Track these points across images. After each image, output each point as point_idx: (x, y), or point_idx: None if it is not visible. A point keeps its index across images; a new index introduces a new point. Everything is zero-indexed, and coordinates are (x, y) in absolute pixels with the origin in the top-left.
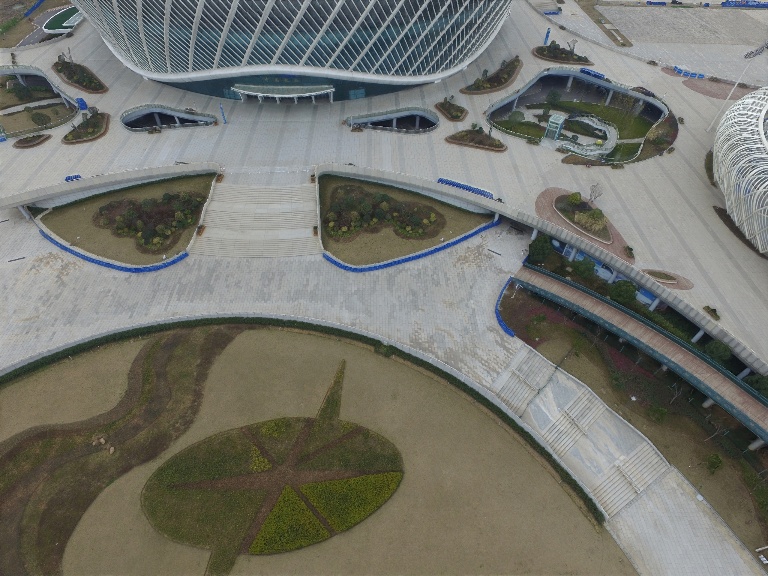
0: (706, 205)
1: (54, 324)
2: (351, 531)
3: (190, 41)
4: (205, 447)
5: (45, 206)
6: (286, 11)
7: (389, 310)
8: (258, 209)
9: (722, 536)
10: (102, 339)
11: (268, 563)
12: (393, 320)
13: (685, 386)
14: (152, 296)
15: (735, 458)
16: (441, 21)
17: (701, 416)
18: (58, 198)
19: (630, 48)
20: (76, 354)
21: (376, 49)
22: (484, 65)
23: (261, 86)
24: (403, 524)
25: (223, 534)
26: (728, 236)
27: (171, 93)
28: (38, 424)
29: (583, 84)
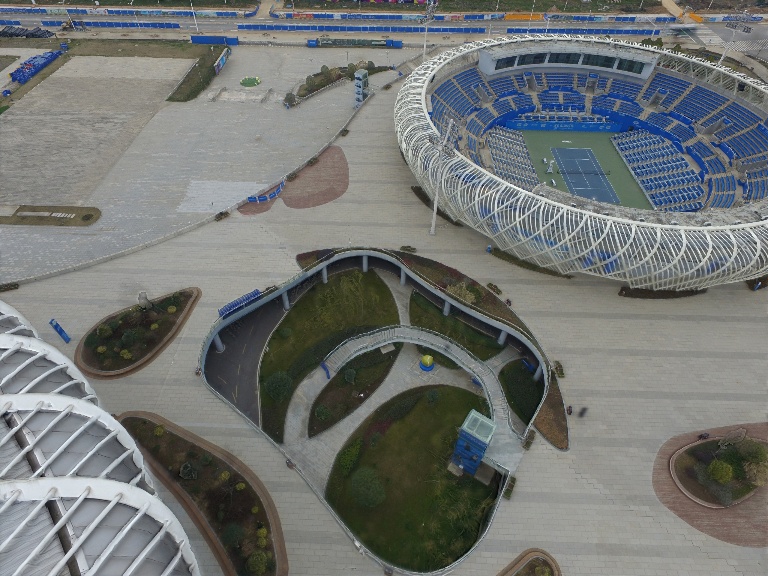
0: (620, 301)
1: None
2: None
3: None
4: None
5: None
6: None
7: None
8: None
9: None
10: None
11: None
12: None
13: None
14: None
15: None
16: None
17: None
18: None
19: (105, 215)
20: None
21: None
22: None
23: None
24: None
25: None
26: (679, 305)
27: None
28: None
29: None
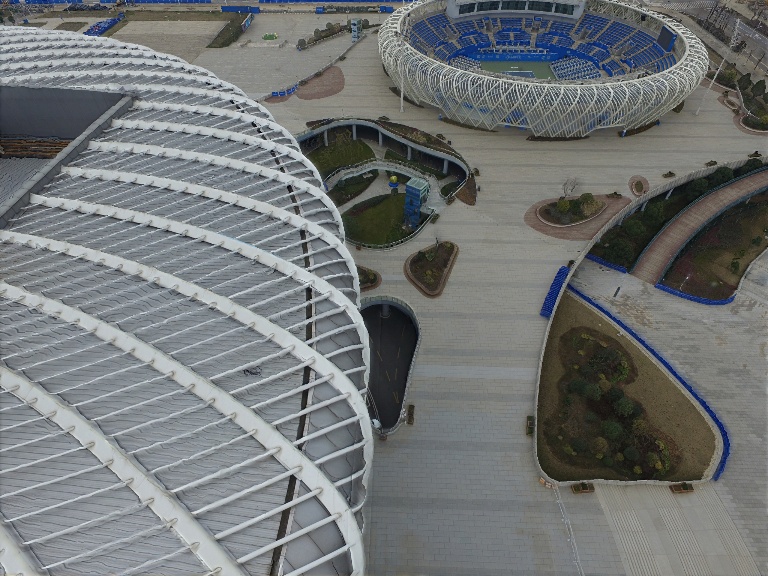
0: (526, 143)
1: None
2: None
3: None
4: None
5: None
6: None
7: (766, 399)
8: None
9: None
10: None
11: None
12: None
13: None
14: None
15: None
16: None
17: None
18: None
19: None
20: None
21: None
22: None
23: None
24: None
25: None
26: (567, 144)
27: None
28: None
29: None
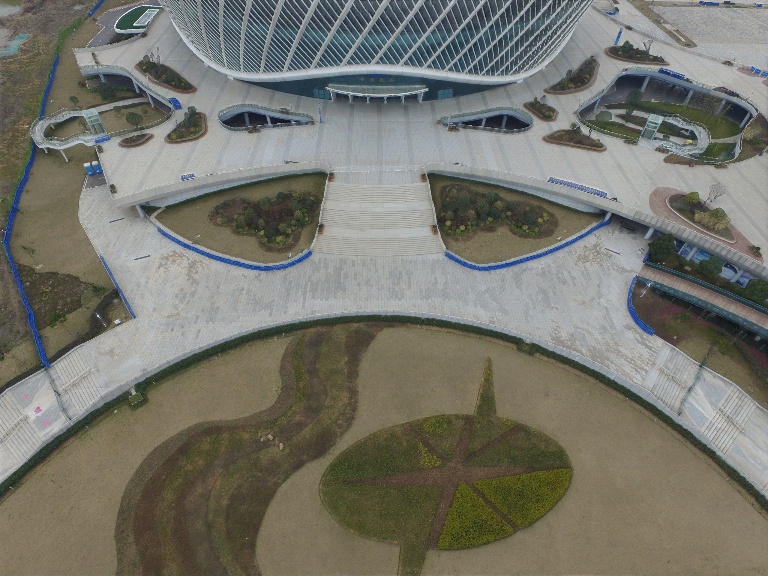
0: None
1: (197, 321)
2: (533, 527)
3: (294, 41)
4: (372, 443)
5: (158, 205)
6: (399, 11)
7: (524, 308)
8: (374, 208)
9: None
10: (248, 336)
11: (458, 558)
12: (530, 318)
13: None
14: (286, 294)
15: None
16: (538, 21)
17: None
18: (172, 197)
19: (695, 48)
20: (224, 351)
21: (475, 49)
22: (561, 65)
23: (355, 86)
24: (583, 520)
25: (408, 529)
26: None
27: (259, 93)
28: (202, 420)
29: (657, 84)
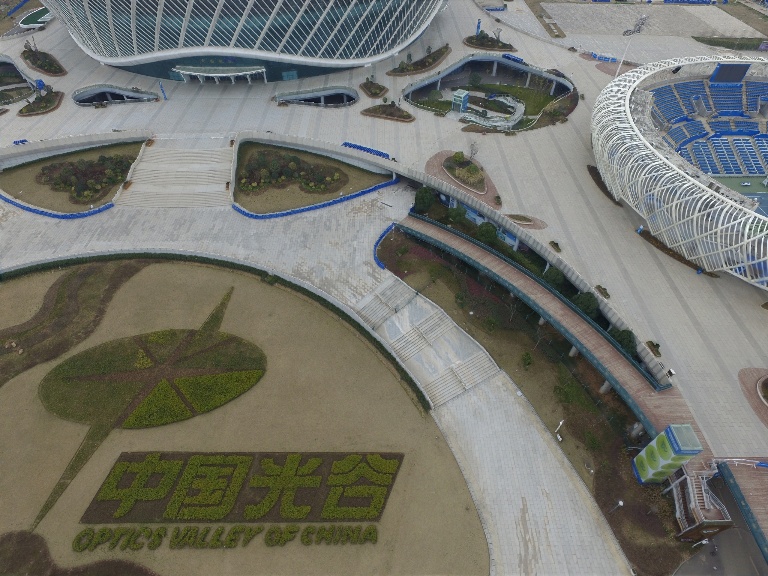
0: (581, 164)
1: None
2: (211, 413)
3: (131, 25)
4: (100, 350)
5: None
6: None
7: (280, 248)
8: (180, 168)
9: (530, 421)
10: (26, 269)
11: (137, 435)
12: (281, 256)
13: (526, 307)
14: (76, 237)
15: (555, 362)
16: (358, 7)
17: (533, 330)
18: (7, 160)
19: (563, 39)
20: (3, 281)
21: (298, 32)
22: (415, 52)
23: (199, 67)
24: (256, 408)
25: (103, 413)
26: (592, 188)
27: (123, 76)
28: None
29: (509, 69)
